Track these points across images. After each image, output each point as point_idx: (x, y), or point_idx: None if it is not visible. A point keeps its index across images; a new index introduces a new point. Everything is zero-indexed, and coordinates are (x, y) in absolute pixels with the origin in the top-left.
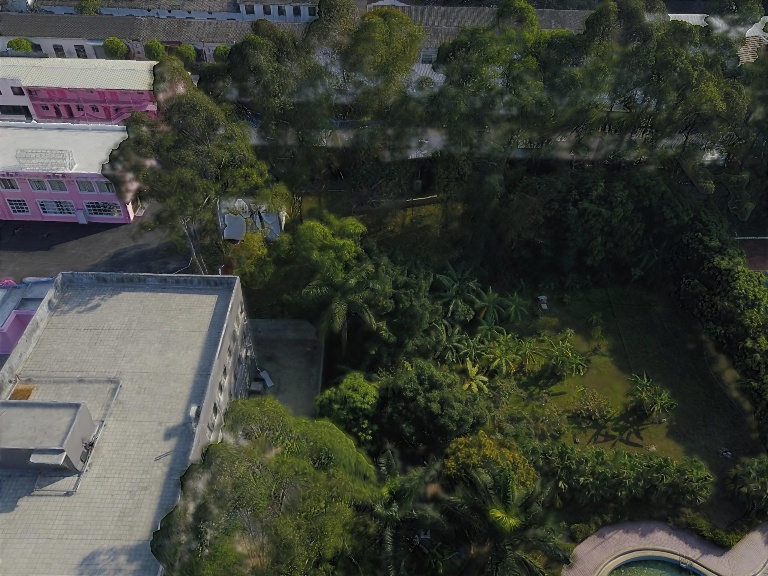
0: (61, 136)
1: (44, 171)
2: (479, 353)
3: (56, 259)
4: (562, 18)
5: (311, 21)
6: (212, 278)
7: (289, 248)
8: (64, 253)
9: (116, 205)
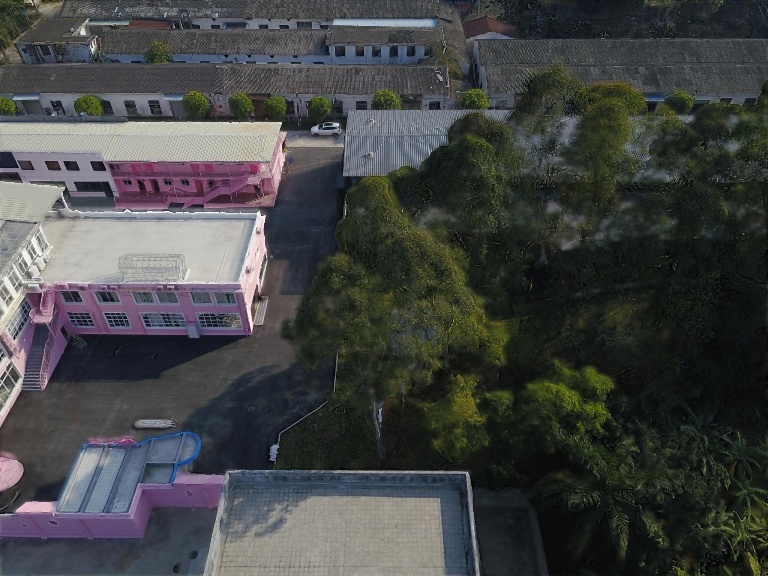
0: (161, 229)
1: (153, 283)
2: (755, 539)
3: (170, 391)
4: (696, 50)
5: (409, 62)
6: (431, 475)
7: (503, 408)
8: (178, 381)
9: (235, 316)
